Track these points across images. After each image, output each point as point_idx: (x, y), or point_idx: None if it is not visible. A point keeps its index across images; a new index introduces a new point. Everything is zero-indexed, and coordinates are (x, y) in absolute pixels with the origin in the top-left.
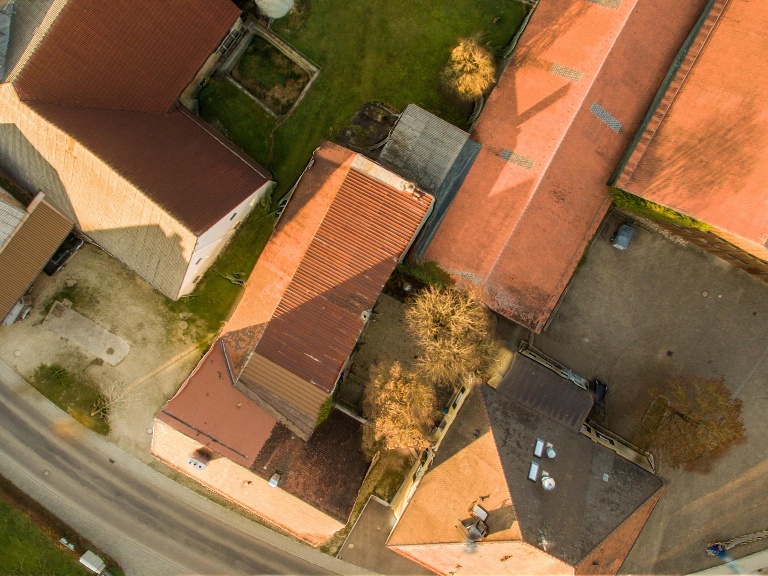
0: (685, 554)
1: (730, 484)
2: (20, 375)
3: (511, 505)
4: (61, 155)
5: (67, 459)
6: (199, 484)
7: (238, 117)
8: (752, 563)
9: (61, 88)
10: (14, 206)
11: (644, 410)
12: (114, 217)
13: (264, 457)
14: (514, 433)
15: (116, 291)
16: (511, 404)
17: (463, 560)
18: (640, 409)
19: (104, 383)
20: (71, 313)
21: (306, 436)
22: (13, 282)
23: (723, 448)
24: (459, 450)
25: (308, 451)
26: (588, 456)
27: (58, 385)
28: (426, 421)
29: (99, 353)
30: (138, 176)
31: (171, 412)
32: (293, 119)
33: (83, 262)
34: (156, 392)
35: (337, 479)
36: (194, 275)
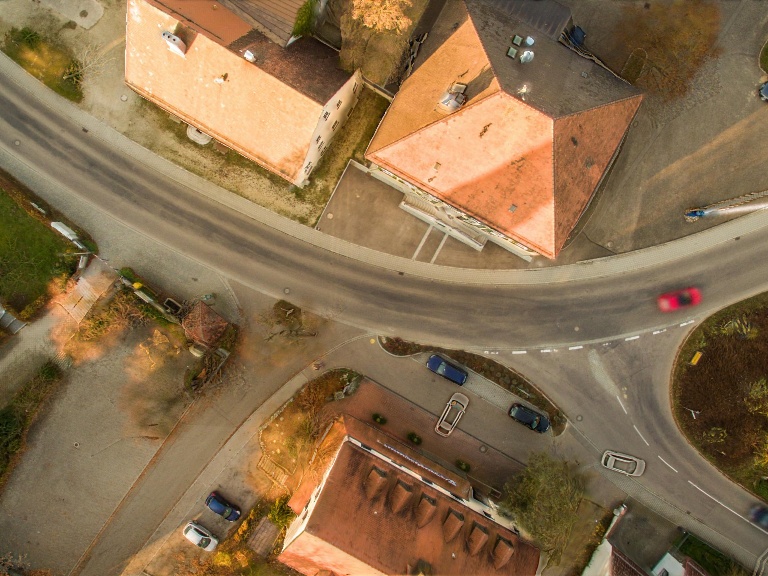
0: (664, 221)
1: (707, 146)
2: None
3: (490, 67)
4: None
5: (39, 128)
6: (175, 153)
7: None
8: (730, 231)
9: None
10: None
11: (622, 63)
12: None
13: (240, 45)
14: (493, 25)
15: None
16: (490, 7)
17: (442, 151)
18: (618, 61)
19: (77, 47)
20: None
21: (283, 42)
22: None
23: (700, 106)
24: (438, 47)
25: (285, 54)
26: (567, 58)
27: (29, 49)
28: (405, 49)
29: (72, 16)
30: None
31: None
32: None
33: None
34: None
35: (315, 78)
36: None
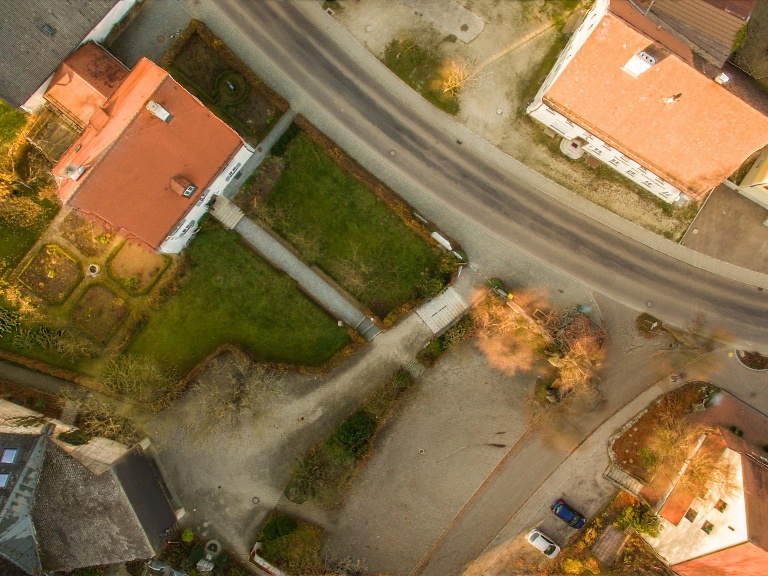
0: None
1: None
2: (370, 51)
3: None
4: None
5: (414, 139)
6: (546, 166)
7: None
8: None
9: None
10: None
11: None
12: None
13: (699, 66)
14: None
15: None
16: None
17: None
18: None
19: (456, 61)
20: None
21: (720, 63)
22: None
23: None
24: None
25: None
26: None
27: (409, 62)
28: None
29: (453, 29)
30: None
31: None
32: None
33: None
34: (509, 70)
35: (758, 99)
36: None
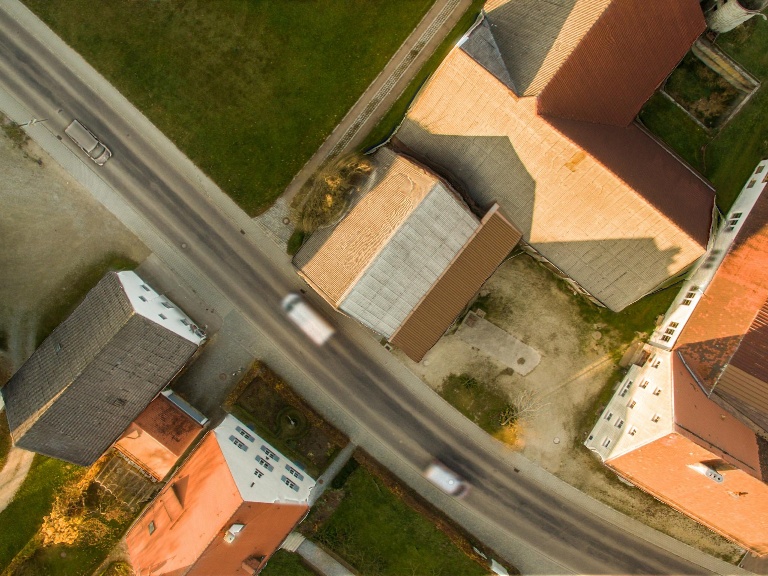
0: None
1: None
2: (428, 384)
3: None
4: (555, 168)
5: (472, 468)
6: (604, 493)
7: (669, 130)
8: None
9: (566, 102)
10: (474, 217)
11: None
12: (590, 230)
13: (766, 469)
14: None
15: (530, 301)
16: None
17: None
18: None
19: (513, 393)
20: (484, 323)
21: None
22: (460, 293)
23: None
24: None
25: None
26: None
27: (467, 395)
28: None
29: (510, 363)
30: (642, 190)
31: (681, 424)
32: (725, 132)
33: (498, 272)
34: (566, 402)
35: None
36: (659, 287)
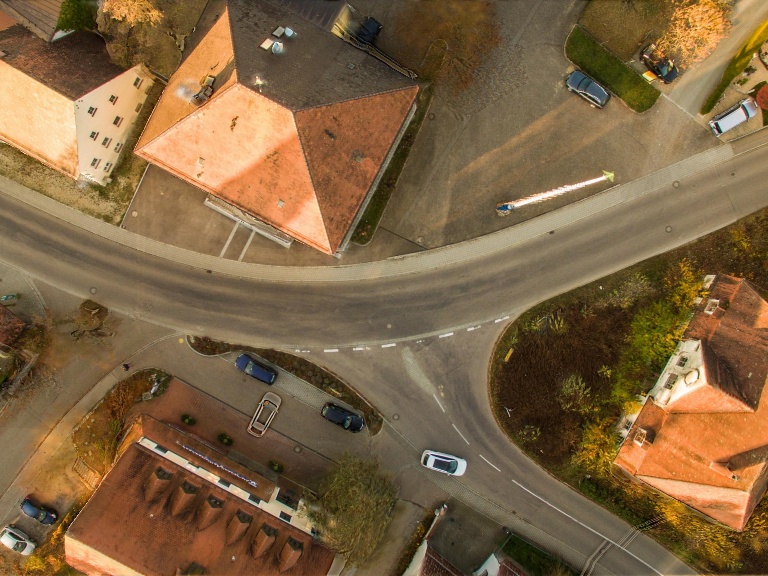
0: (475, 215)
1: (516, 138)
2: None
3: (233, 59)
4: None
5: None
6: None
7: None
8: (543, 224)
9: None
10: None
11: (422, 54)
12: None
13: None
14: (254, 17)
15: None
16: None
17: (202, 146)
18: (418, 53)
19: None
20: None
21: (48, 36)
22: None
23: (506, 98)
24: (201, 40)
25: (48, 49)
26: (336, 49)
27: None
28: None
29: None
30: None
31: None
32: None
33: None
34: None
35: (75, 72)
36: None
